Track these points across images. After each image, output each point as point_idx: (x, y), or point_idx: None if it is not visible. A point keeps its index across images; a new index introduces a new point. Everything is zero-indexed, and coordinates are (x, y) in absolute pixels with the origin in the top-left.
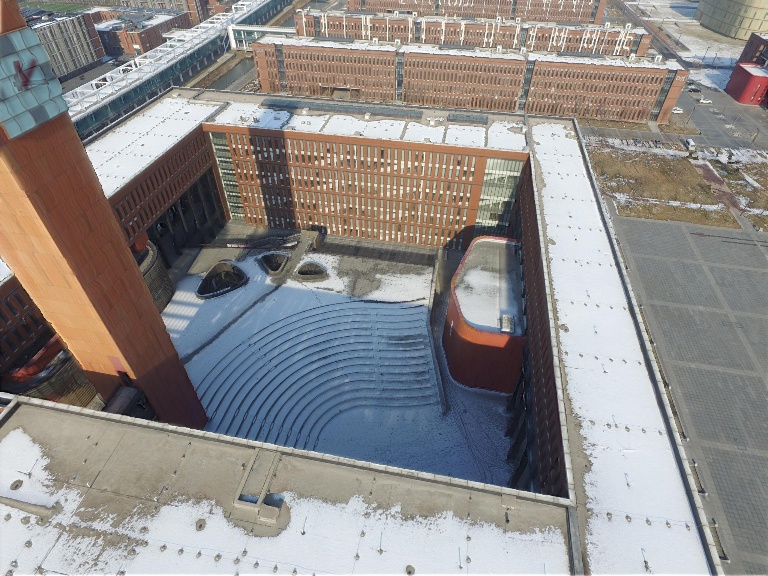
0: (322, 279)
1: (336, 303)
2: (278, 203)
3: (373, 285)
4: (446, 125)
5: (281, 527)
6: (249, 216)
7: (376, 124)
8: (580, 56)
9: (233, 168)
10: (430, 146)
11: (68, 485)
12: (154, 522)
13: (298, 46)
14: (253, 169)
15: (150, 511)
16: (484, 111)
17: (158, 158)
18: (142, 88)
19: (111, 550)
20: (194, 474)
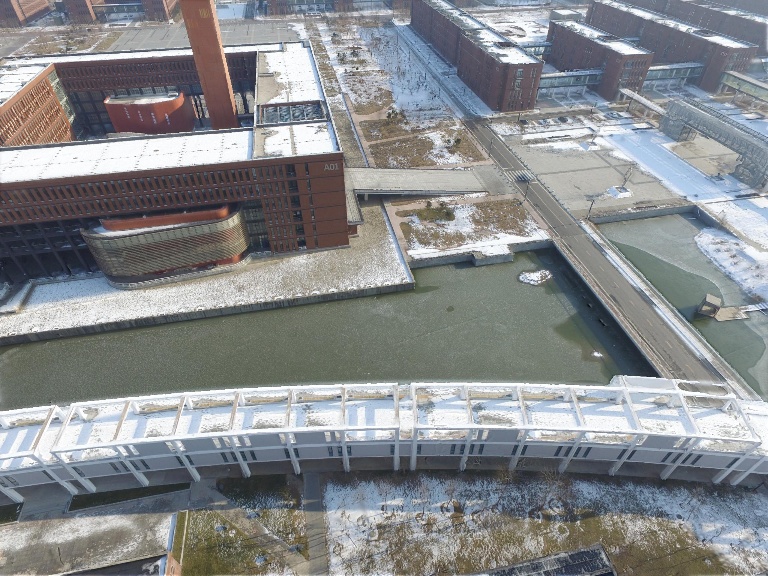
0: None
1: None
2: None
3: None
4: None
5: None
6: None
7: None
8: None
9: None
10: (31, 83)
11: None
12: None
13: None
14: None
15: None
16: None
17: None
18: None
19: None
20: None
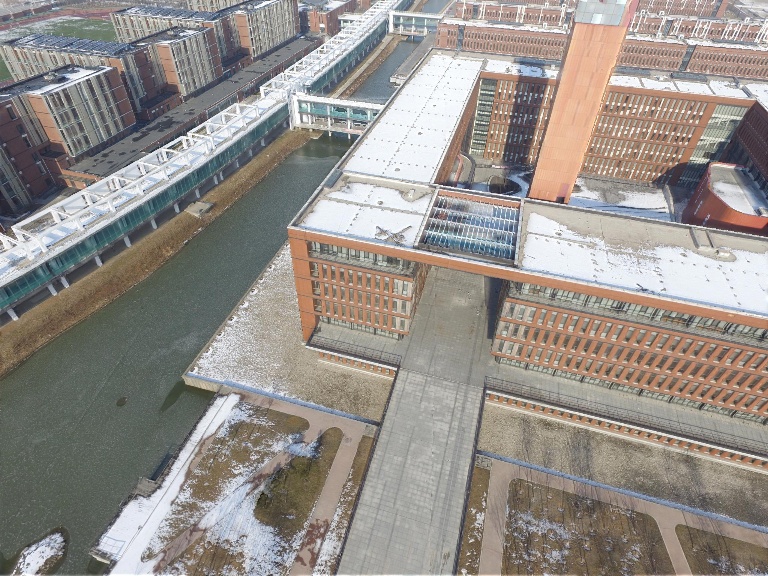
0: (578, 191)
1: (597, 206)
2: (519, 140)
3: (620, 197)
4: (673, 81)
5: (733, 259)
6: (488, 151)
7: (616, 78)
8: (734, 43)
9: (489, 110)
10: (671, 93)
11: (589, 236)
12: (656, 252)
13: (480, 27)
14: (509, 110)
15: (649, 248)
16: (699, 73)
17: (472, 90)
18: (349, 57)
19: (643, 259)
20: (660, 237)
